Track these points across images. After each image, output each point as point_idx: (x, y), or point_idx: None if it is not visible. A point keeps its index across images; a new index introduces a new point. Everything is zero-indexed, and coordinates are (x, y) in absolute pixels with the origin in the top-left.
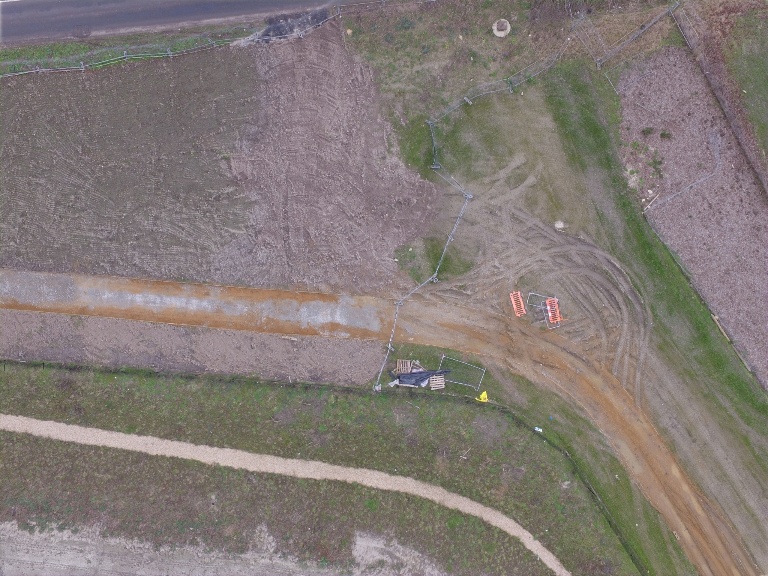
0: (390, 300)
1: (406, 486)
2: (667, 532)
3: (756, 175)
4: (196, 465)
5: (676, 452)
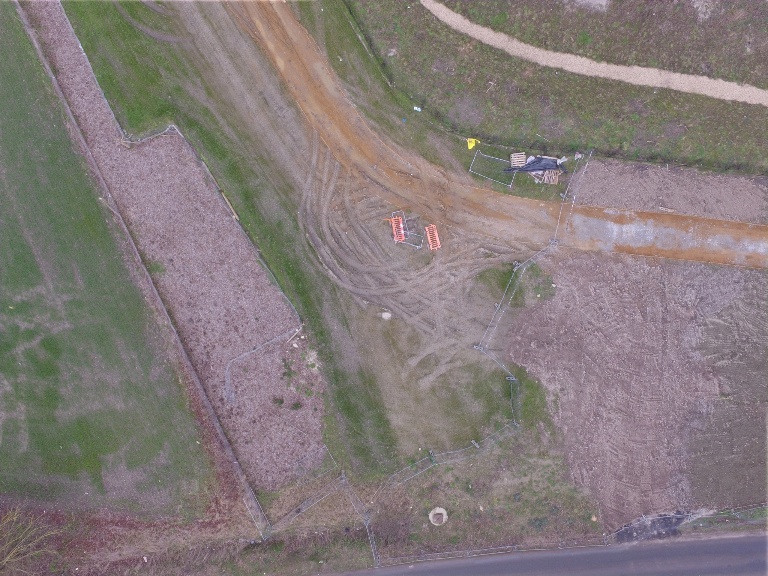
0: (562, 245)
1: (547, 57)
2: (292, 2)
3: (190, 358)
4: (762, 84)
5: (279, 83)
